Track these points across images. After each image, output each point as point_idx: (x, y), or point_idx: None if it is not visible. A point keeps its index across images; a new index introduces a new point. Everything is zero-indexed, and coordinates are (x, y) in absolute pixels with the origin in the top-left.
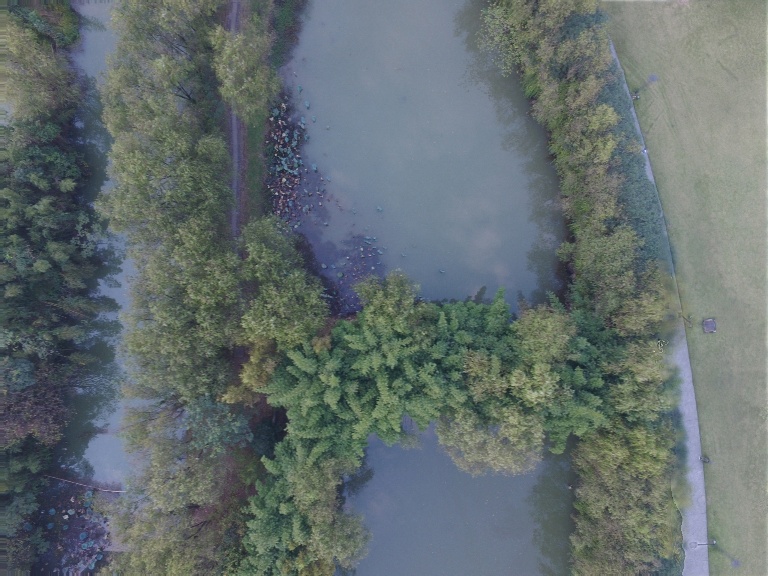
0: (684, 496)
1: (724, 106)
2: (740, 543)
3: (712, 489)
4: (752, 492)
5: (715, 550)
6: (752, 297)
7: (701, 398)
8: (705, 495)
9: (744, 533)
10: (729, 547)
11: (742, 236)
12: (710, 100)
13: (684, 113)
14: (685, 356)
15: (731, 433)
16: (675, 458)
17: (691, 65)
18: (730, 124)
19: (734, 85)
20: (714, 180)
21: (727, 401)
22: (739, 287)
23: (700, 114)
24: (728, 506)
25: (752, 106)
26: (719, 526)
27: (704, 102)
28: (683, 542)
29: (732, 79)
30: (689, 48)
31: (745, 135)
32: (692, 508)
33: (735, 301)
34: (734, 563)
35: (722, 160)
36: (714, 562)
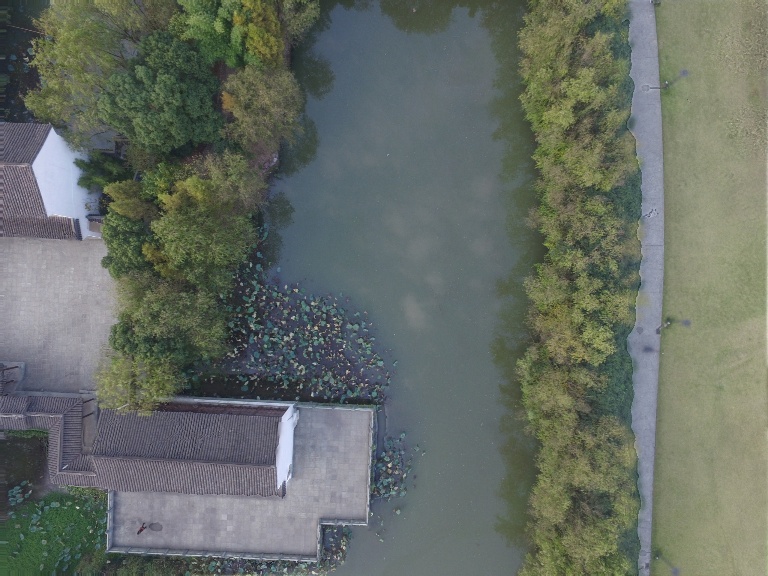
0: (636, 39)
1: None
2: (693, 88)
3: (664, 34)
4: (704, 40)
5: (667, 94)
6: None
7: None
8: (657, 39)
9: (696, 79)
10: (681, 91)
11: None
12: None
13: None
14: None
15: None
16: (626, 1)
17: None
18: None
19: None
20: None
21: None
22: None
23: None
24: (680, 52)
25: None
26: (671, 71)
27: None
28: (635, 85)
29: None
30: None
31: None
32: (644, 51)
33: None
34: (687, 107)
35: None
36: (667, 106)
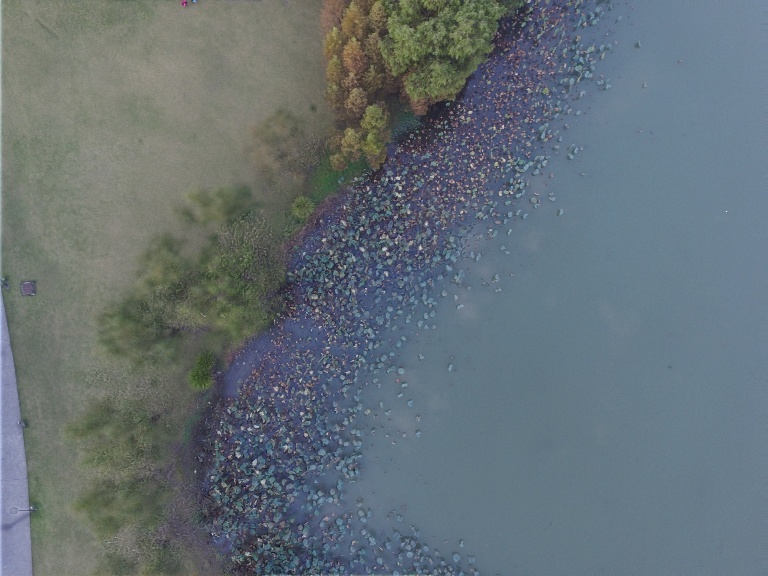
0: (3, 461)
1: (44, 66)
2: (64, 510)
3: (34, 454)
4: (80, 458)
5: (37, 516)
6: (74, 260)
7: (21, 362)
8: (26, 460)
9: (68, 500)
10: (51, 513)
11: (62, 198)
12: (28, 59)
13: (1, 73)
14: (2, 319)
15: (55, 398)
16: None
17: (7, 24)
18: (49, 84)
19: (54, 44)
20: (32, 141)
21: (50, 365)
22: (60, 250)
23: (17, 74)
24: (52, 472)
25: (73, 65)
26: (41, 492)
27: (22, 62)
28: (3, 507)
29: (52, 38)
30: (5, 7)
31: (65, 95)
32: (12, 473)
33: (57, 264)
34: (57, 530)
35: (41, 120)
36: (36, 528)
